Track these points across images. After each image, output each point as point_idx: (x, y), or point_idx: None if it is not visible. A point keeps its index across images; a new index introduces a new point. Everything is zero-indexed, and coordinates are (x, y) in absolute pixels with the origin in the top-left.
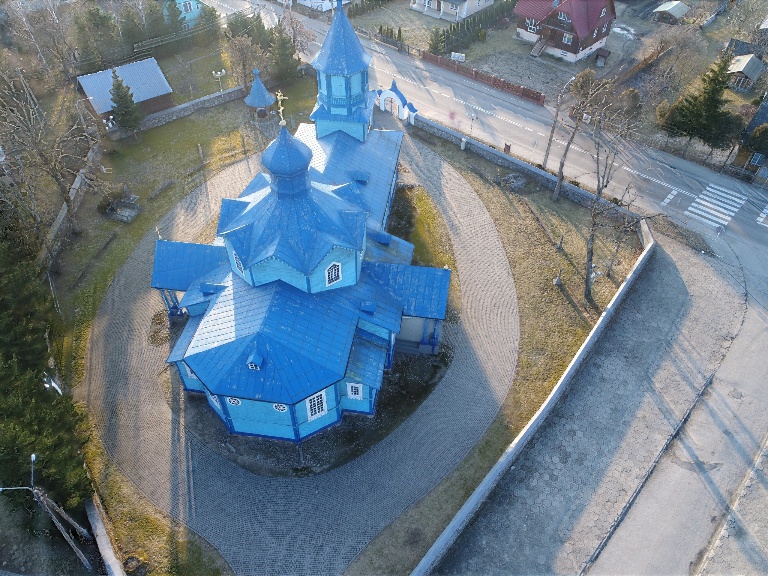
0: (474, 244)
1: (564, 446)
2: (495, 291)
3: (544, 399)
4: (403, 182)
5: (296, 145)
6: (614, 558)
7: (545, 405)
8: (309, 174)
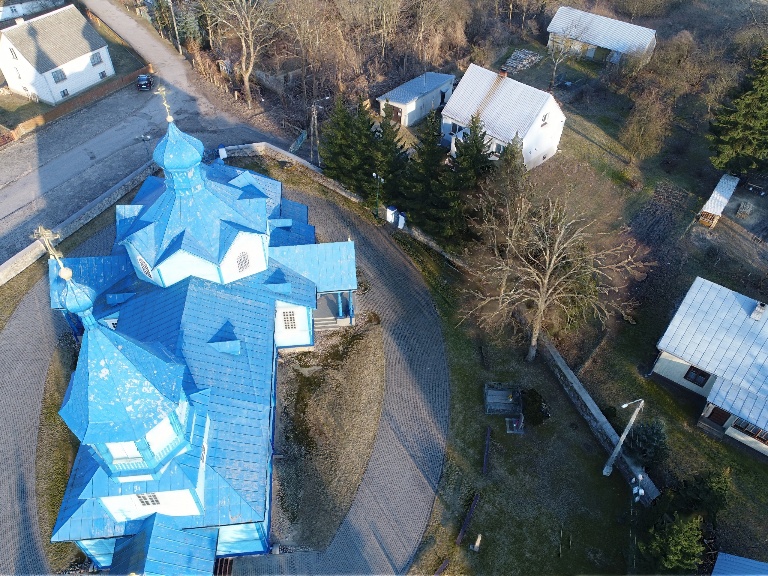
0: (4, 449)
1: (7, 254)
2: (5, 380)
3: (6, 285)
4: (89, 575)
5: (163, 136)
6: (8, 210)
7: (8, 260)
8: (182, 240)
